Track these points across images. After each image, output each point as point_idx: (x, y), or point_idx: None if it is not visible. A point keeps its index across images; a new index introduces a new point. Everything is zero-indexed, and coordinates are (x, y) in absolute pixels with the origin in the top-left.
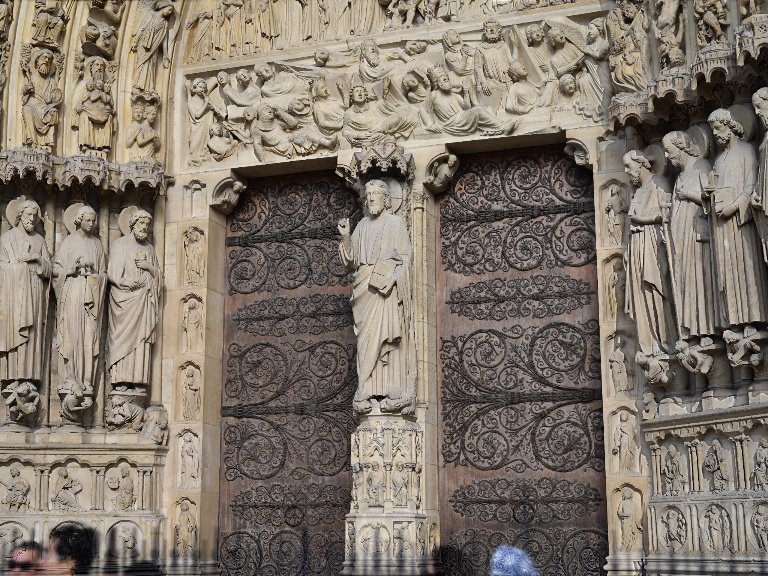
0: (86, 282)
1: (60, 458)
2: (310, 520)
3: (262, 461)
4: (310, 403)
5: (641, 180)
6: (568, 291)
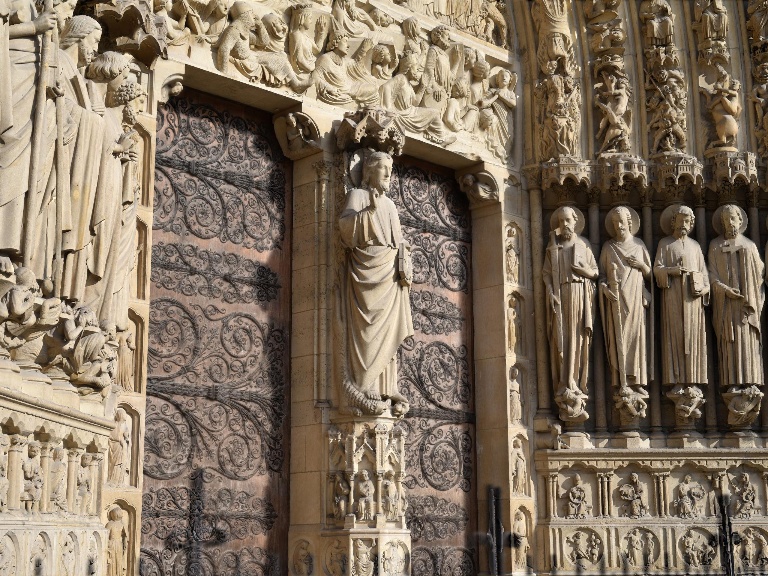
0: (128, 169)
1: (68, 431)
2: (221, 534)
3: (165, 455)
4: (224, 387)
5: (572, 235)
6: (447, 313)
